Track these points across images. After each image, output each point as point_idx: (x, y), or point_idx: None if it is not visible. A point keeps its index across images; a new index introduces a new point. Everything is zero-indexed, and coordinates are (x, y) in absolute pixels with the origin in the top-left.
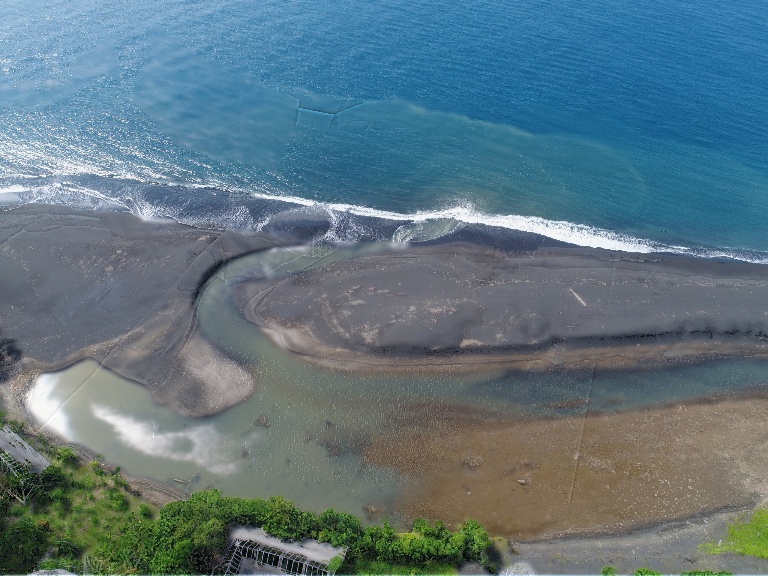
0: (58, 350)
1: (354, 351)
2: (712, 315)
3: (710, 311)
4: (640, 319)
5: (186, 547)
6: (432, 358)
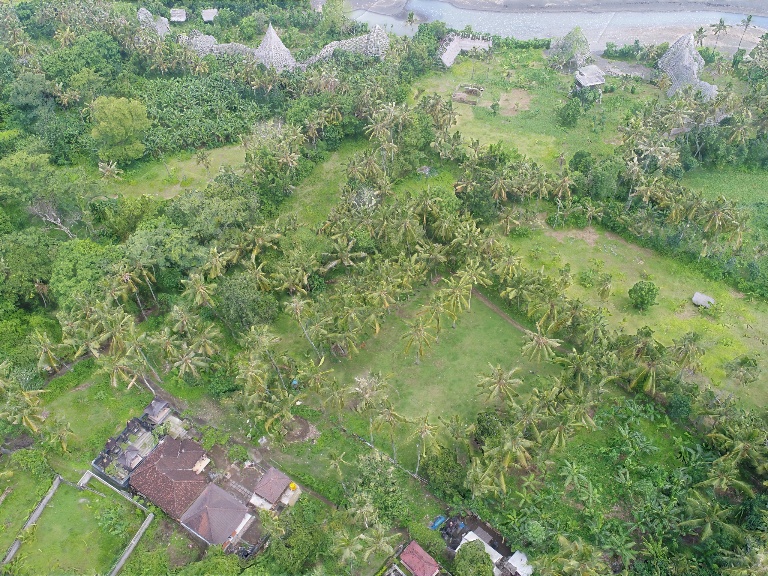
0: (346, 6)
1: (491, 7)
2: None
3: None
4: None
5: (435, 26)
6: (531, 9)
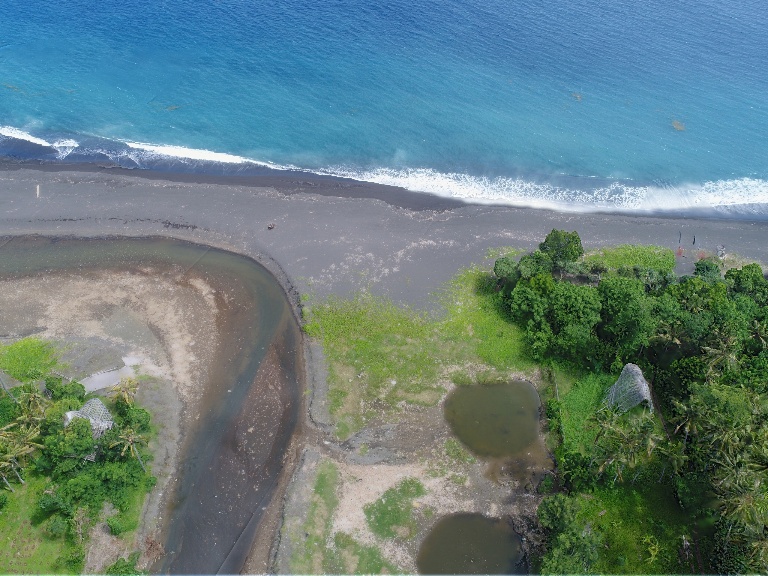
0: None
1: None
2: (135, 206)
3: (137, 203)
4: (72, 207)
5: None
6: None
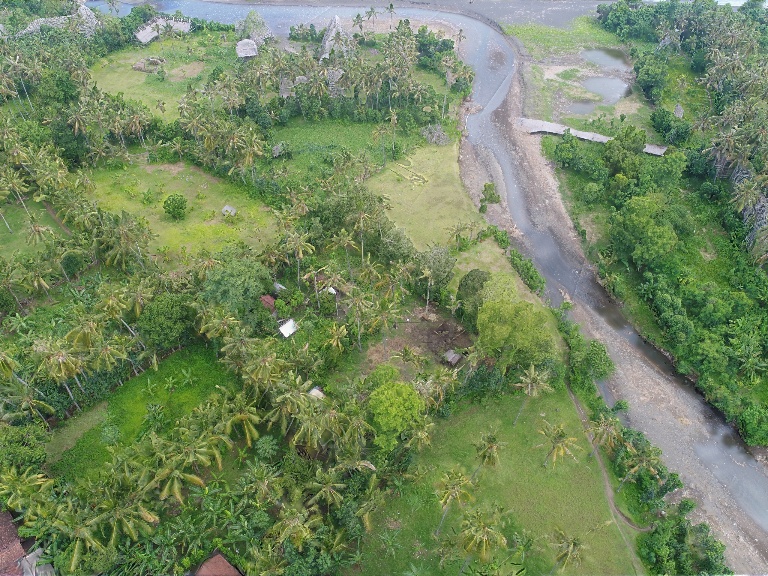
0: None
1: None
2: None
3: None
4: None
5: (140, 8)
6: (259, 2)
